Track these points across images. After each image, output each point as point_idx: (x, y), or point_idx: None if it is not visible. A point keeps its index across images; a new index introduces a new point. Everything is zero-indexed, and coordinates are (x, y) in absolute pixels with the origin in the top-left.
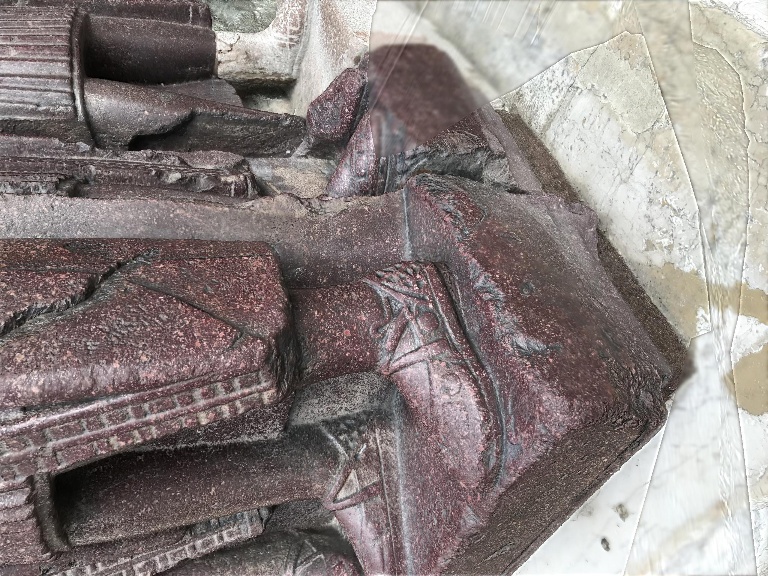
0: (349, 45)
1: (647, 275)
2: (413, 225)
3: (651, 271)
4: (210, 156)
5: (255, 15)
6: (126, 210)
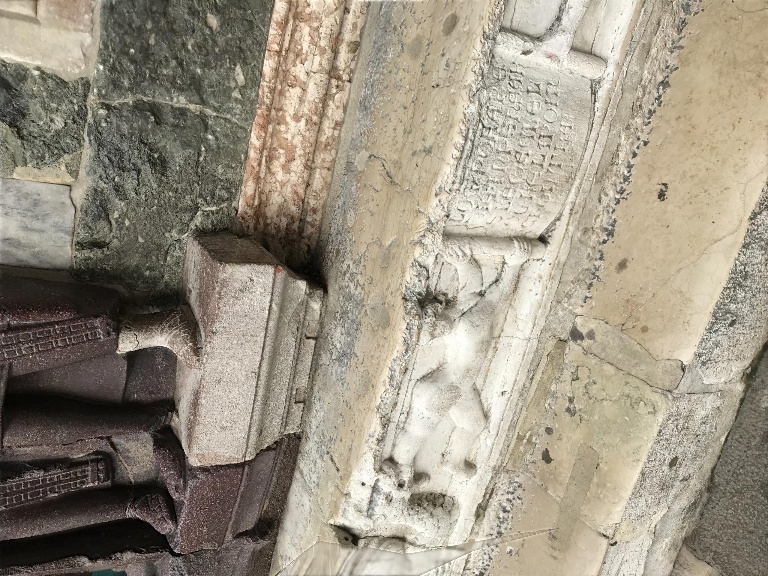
0: (189, 458)
1: (276, 556)
2: None
3: (277, 559)
4: (84, 446)
5: (200, 156)
6: (19, 575)
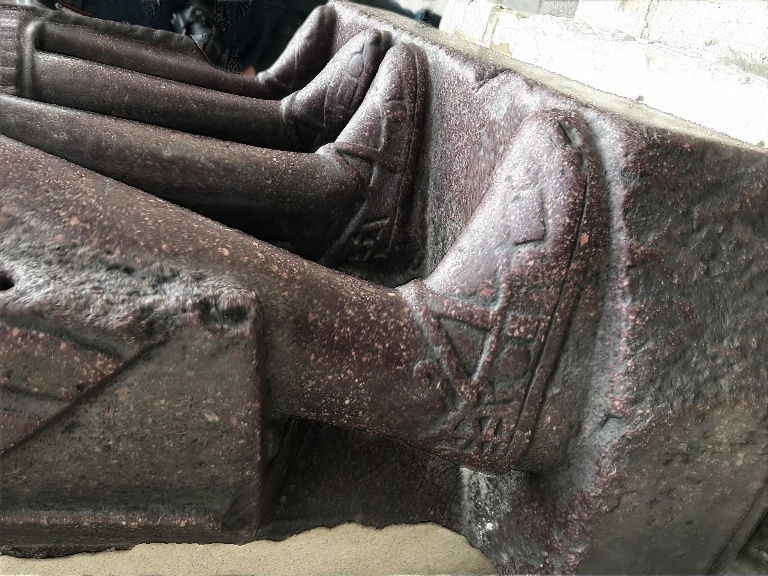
0: None
1: None
2: None
3: None
4: None
5: None
6: None
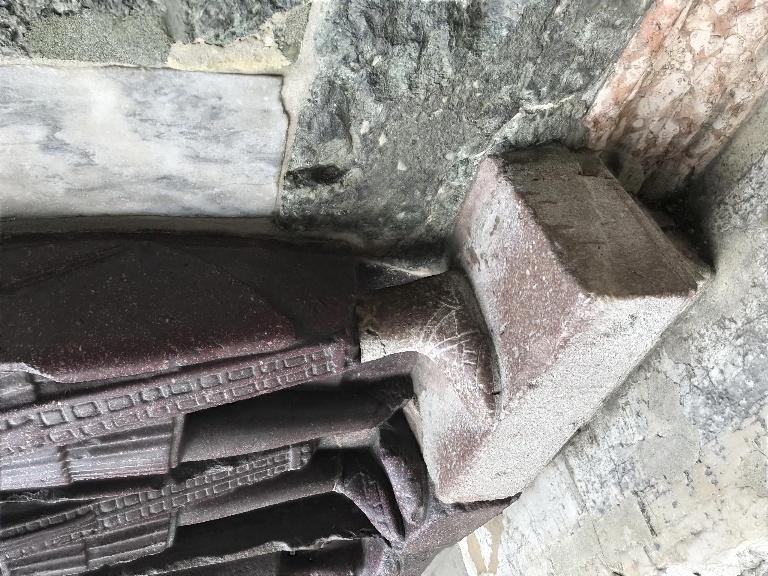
0: (439, 495)
1: None
2: (374, 539)
3: None
4: None
5: (557, 5)
6: None
